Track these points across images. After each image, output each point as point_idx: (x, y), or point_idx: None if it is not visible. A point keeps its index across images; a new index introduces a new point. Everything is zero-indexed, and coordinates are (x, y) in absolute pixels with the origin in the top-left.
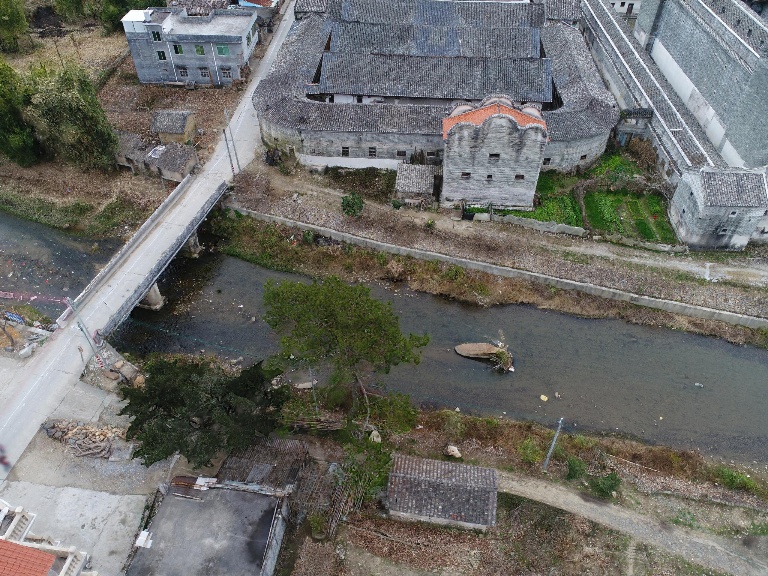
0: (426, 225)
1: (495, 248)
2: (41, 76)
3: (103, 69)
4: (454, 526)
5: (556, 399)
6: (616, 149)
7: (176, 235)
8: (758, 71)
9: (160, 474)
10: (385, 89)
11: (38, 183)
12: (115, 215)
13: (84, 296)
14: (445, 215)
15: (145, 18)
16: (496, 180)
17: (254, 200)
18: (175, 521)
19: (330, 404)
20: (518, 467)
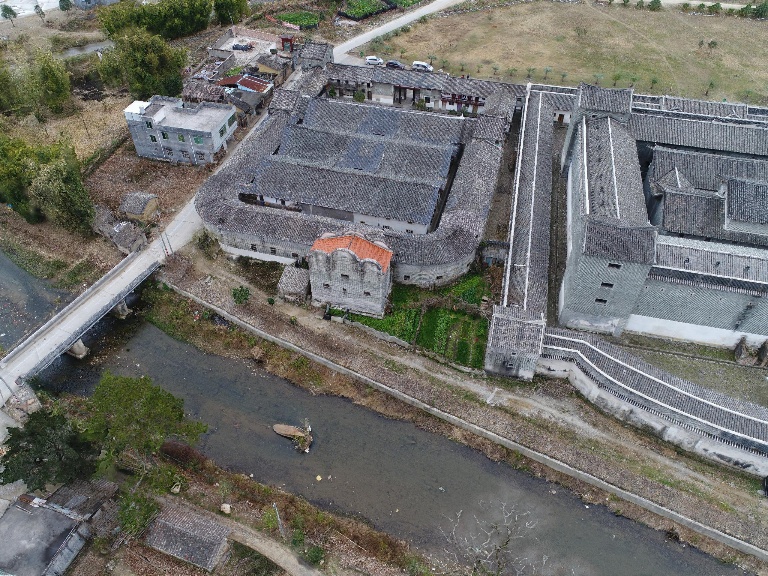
0: (290, 321)
1: (335, 348)
2: (54, 154)
3: (119, 136)
4: (191, 563)
5: (327, 481)
6: (478, 271)
7: (106, 303)
8: (578, 232)
9: (25, 488)
10: (301, 197)
11: (37, 238)
12: (81, 273)
13: (24, 345)
14: (312, 313)
15: (140, 112)
16: (350, 293)
17: None
18: (10, 524)
19: (162, 455)
20: (266, 529)
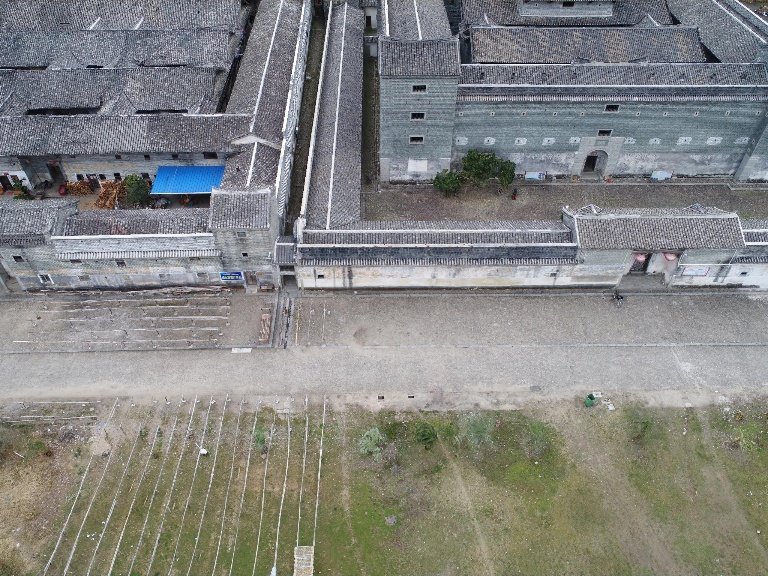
0: None
1: None
2: None
3: None
4: None
5: None
6: None
7: None
8: None
9: None
10: None
11: None
12: None
13: None
14: None
15: None
16: None
17: None
18: None
19: None
20: None
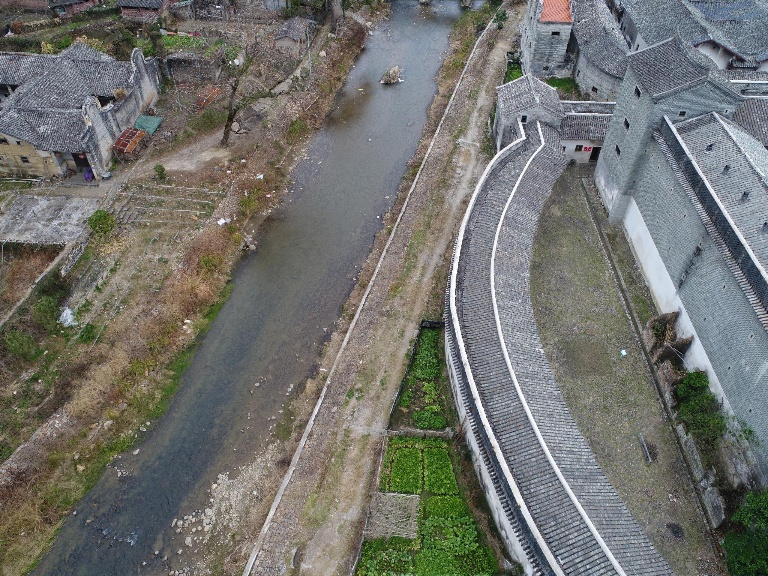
0: None
1: None
2: None
3: None
4: None
5: (360, 93)
6: None
7: None
8: None
9: None
10: None
11: None
12: None
13: None
14: None
15: None
16: None
17: (508, 5)
18: None
19: None
20: None
